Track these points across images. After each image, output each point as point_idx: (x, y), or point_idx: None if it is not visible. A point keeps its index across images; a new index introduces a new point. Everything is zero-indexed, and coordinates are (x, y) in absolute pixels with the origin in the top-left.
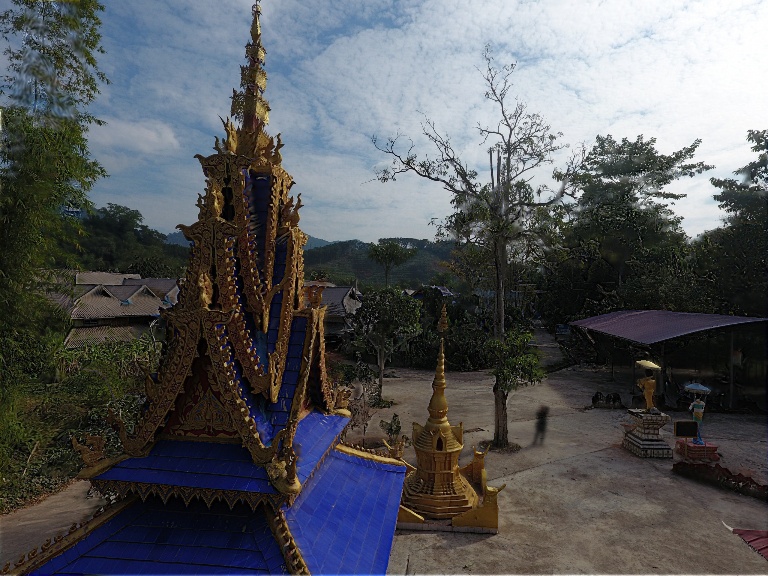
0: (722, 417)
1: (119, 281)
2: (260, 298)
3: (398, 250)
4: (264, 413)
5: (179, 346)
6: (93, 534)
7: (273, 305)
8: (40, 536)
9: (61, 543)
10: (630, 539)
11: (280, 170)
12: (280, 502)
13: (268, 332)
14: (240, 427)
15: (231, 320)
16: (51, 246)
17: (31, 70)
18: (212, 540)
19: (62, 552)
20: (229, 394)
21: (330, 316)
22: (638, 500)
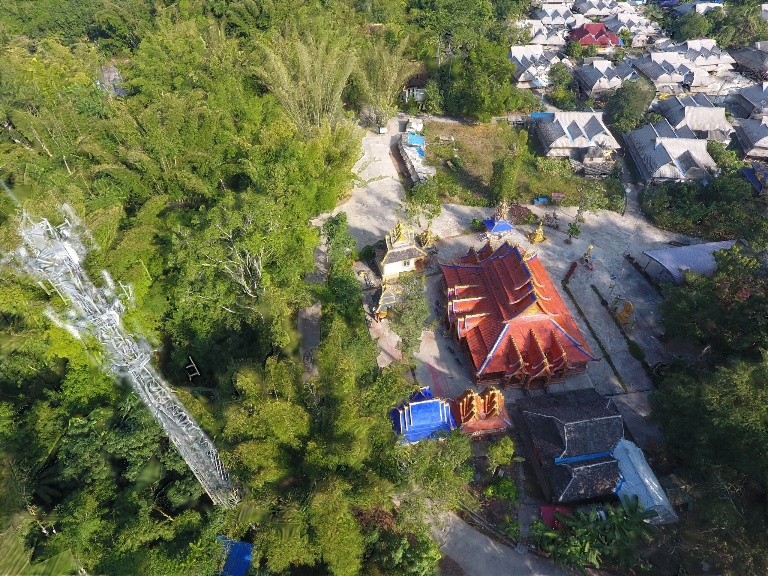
0: (640, 280)
1: (590, 117)
2: None
3: None
4: None
5: None
6: None
7: None
8: None
9: None
10: (542, 255)
11: None
12: None
13: None
14: None
15: None
16: None
17: None
18: None
19: None
20: None
21: None
22: (557, 257)
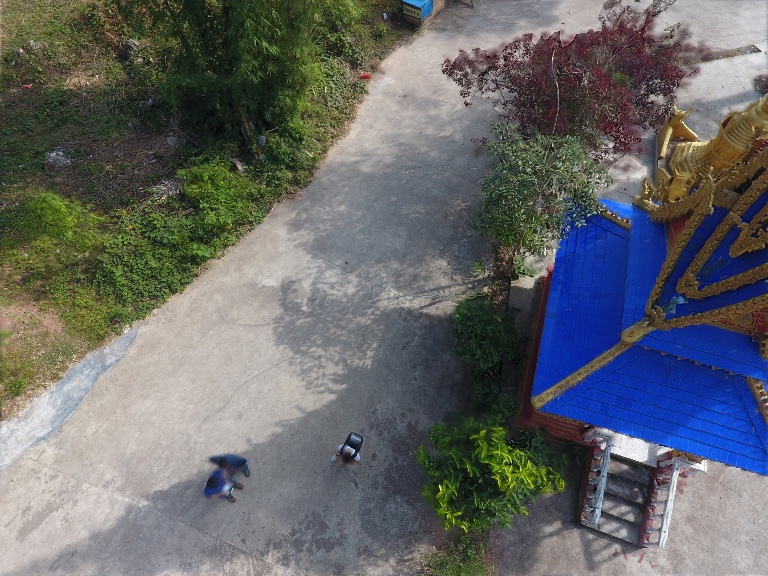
0: None
1: None
2: None
3: None
4: None
5: (761, 298)
6: (617, 359)
7: None
8: (377, 178)
9: (601, 364)
10: None
11: None
12: None
13: None
14: None
15: None
16: None
17: None
18: (703, 379)
19: (600, 367)
20: None
21: None
22: None
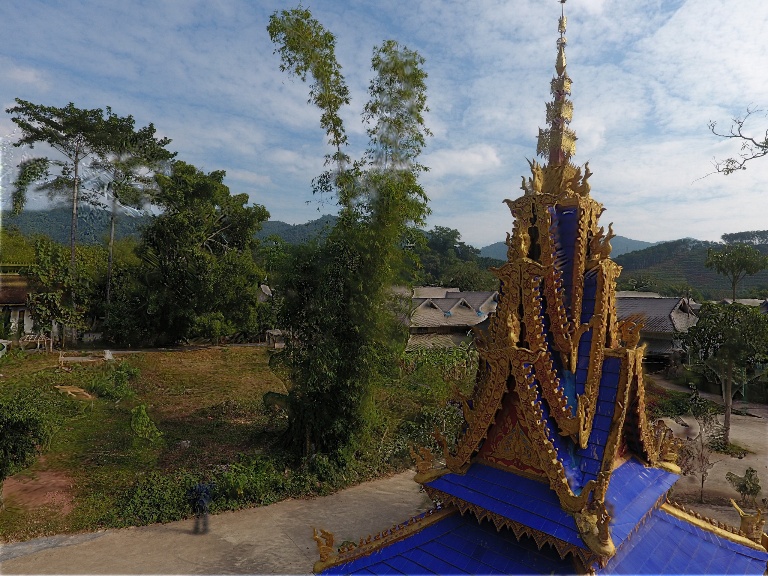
0: None
1: (443, 294)
2: (567, 337)
3: (752, 254)
4: (573, 457)
5: (490, 380)
6: (424, 531)
7: (582, 343)
8: (389, 506)
9: (403, 531)
10: None
11: (588, 200)
12: (591, 560)
13: (576, 371)
14: (548, 468)
15: (538, 358)
16: (396, 275)
17: (383, 138)
18: (521, 573)
19: (404, 539)
20: (536, 433)
21: (653, 332)
22: None
